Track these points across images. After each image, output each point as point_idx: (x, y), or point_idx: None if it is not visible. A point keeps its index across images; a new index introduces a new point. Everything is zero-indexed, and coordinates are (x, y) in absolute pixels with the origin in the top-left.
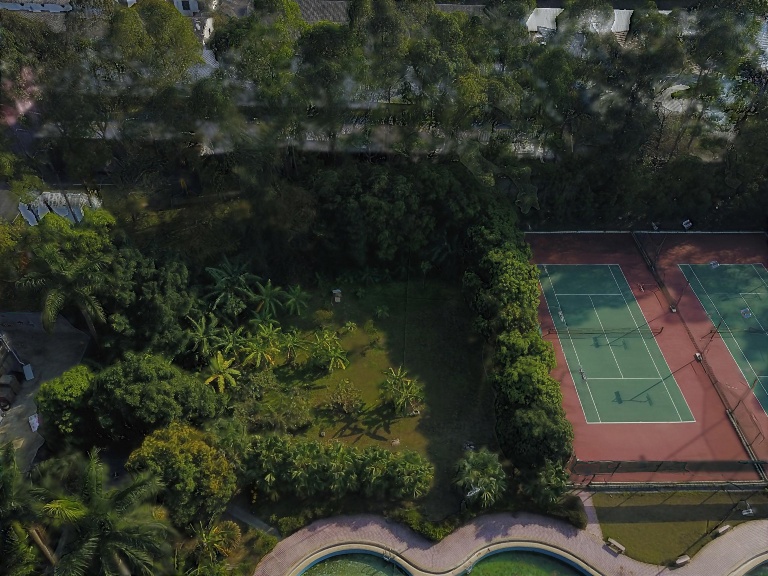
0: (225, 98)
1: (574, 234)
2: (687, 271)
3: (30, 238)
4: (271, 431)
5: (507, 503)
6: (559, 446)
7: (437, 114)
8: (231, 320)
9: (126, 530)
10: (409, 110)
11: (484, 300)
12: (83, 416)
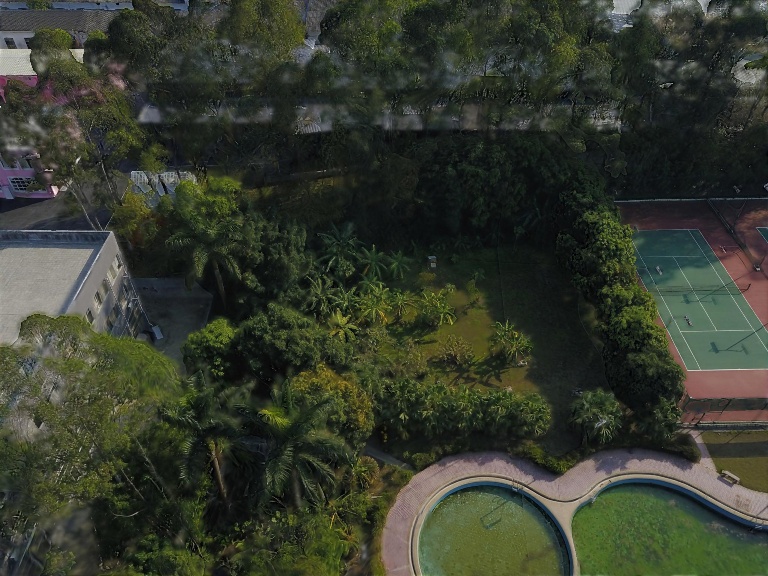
0: (336, 73)
1: (651, 202)
2: (766, 234)
3: (163, 206)
4: (392, 380)
5: (623, 440)
6: (673, 385)
7: (529, 85)
8: (341, 282)
9: (317, 441)
10: (502, 82)
11: (581, 258)
12: (232, 361)
